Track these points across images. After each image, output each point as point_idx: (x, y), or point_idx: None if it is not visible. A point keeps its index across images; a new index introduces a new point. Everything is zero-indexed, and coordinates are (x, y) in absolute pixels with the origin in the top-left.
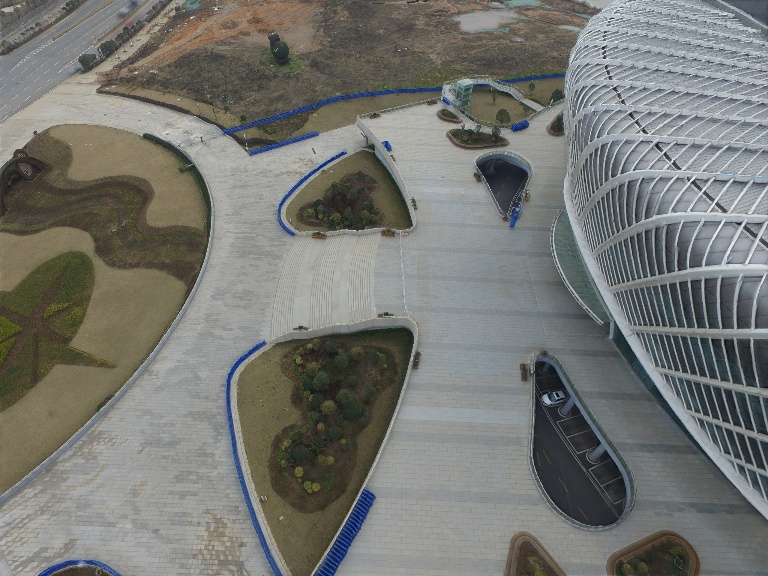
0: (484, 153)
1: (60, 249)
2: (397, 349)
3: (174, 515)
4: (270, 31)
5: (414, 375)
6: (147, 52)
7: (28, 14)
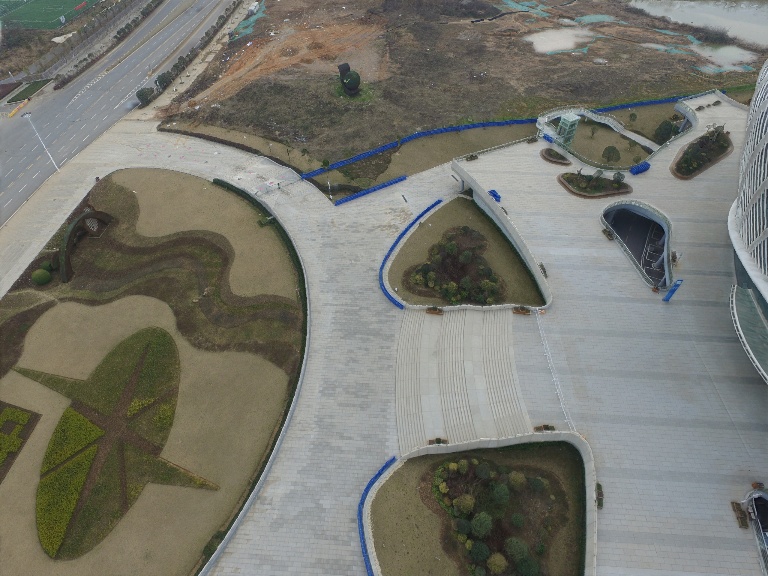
0: (609, 204)
1: (137, 324)
2: (561, 471)
3: None
4: (333, 57)
5: (600, 518)
6: (206, 84)
7: (80, 44)
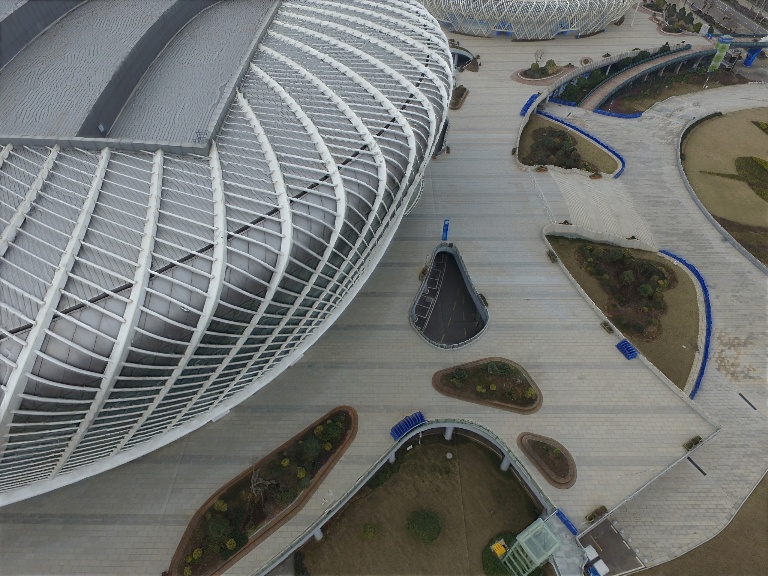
0: None
1: None
2: None
3: (605, 127)
4: None
5: None
6: None
7: None
